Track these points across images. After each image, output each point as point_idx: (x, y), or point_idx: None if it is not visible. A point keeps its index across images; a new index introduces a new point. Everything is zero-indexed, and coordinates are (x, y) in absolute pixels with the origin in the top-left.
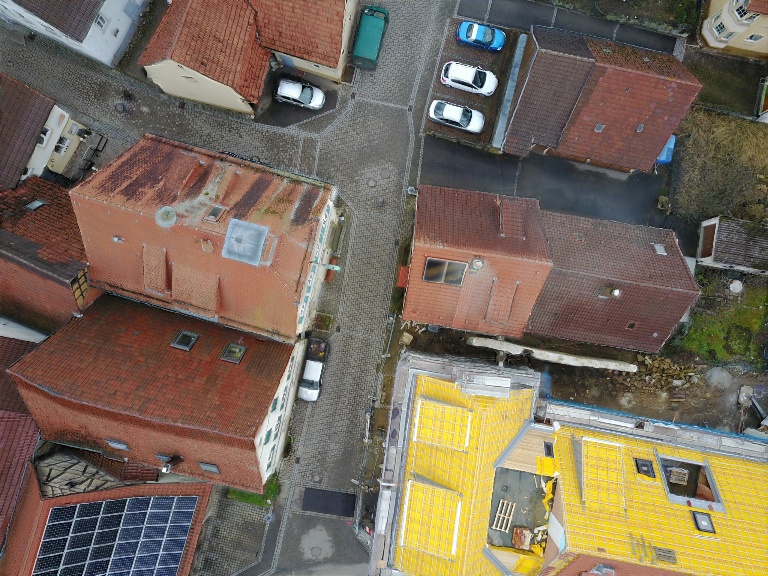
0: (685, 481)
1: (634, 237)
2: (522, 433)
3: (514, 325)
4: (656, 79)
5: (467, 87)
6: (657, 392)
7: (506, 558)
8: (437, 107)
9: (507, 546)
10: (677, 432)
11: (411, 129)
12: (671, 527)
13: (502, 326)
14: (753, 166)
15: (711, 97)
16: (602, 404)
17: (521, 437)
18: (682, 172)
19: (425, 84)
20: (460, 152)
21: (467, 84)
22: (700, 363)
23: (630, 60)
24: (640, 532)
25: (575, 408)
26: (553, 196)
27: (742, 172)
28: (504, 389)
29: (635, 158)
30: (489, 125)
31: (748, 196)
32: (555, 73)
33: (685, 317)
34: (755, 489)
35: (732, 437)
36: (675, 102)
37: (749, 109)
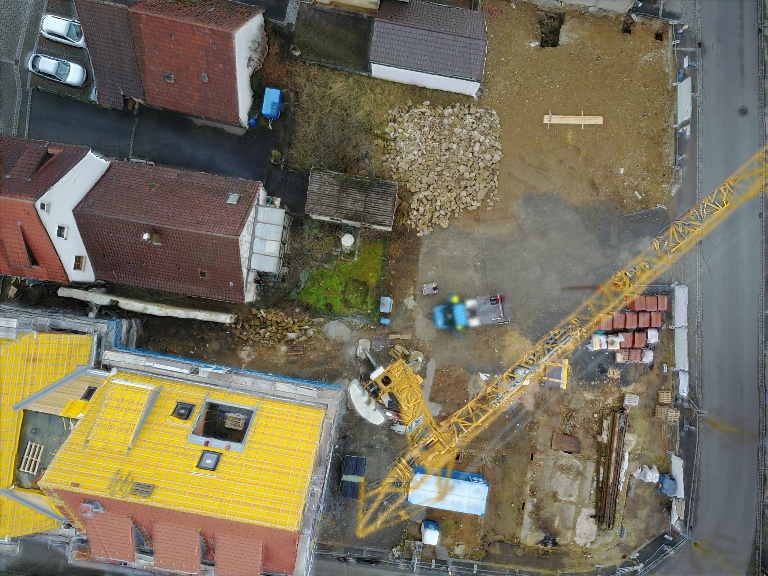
0: (240, 426)
1: (216, 188)
2: (70, 378)
3: (55, 270)
4: (189, 25)
5: (65, 41)
6: (276, 346)
7: (34, 500)
8: (35, 60)
9: (35, 488)
10: (232, 377)
11: (18, 83)
12: (169, 465)
13: (45, 271)
14: (370, 122)
15: (325, 53)
16: (222, 358)
17: (67, 382)
18: (296, 127)
19: (31, 38)
20: (71, 107)
21: (63, 37)
22: (316, 317)
23: (185, 9)
24: (131, 469)
25: (130, 354)
26: (171, 151)
27: (358, 127)
28: (10, 329)
29: (219, 110)
30: (92, 79)
31: (365, 151)
32: (102, 21)
33: (274, 268)
34: (291, 431)
35: (285, 382)
36: (220, 50)
37: (363, 65)
